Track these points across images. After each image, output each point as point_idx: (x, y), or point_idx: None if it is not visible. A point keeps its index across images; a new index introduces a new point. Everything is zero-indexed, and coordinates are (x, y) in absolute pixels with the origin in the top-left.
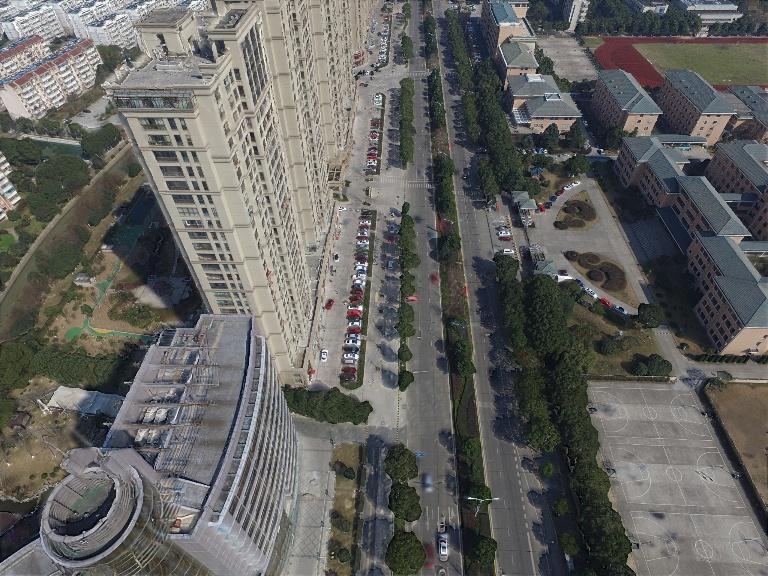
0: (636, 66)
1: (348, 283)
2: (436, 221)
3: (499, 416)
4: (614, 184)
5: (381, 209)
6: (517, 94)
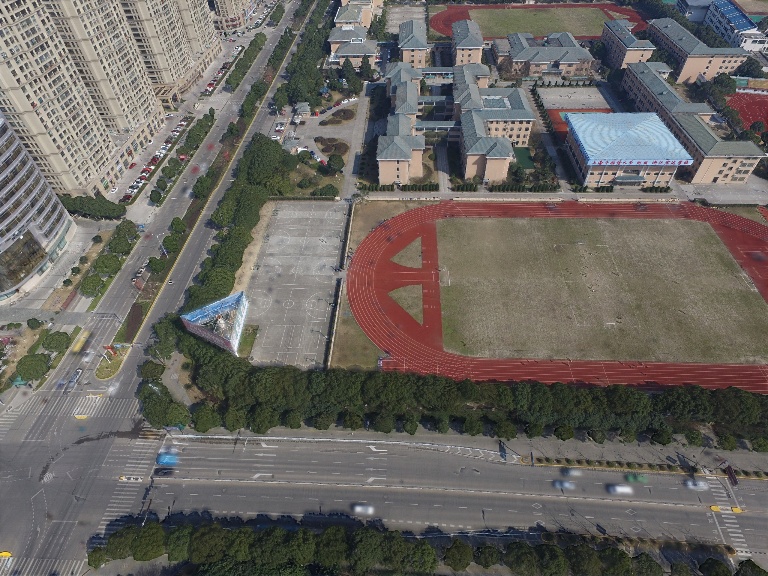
0: None
1: (152, 155)
2: (236, 122)
3: None
4: (380, 99)
5: (200, 116)
6: (331, 39)
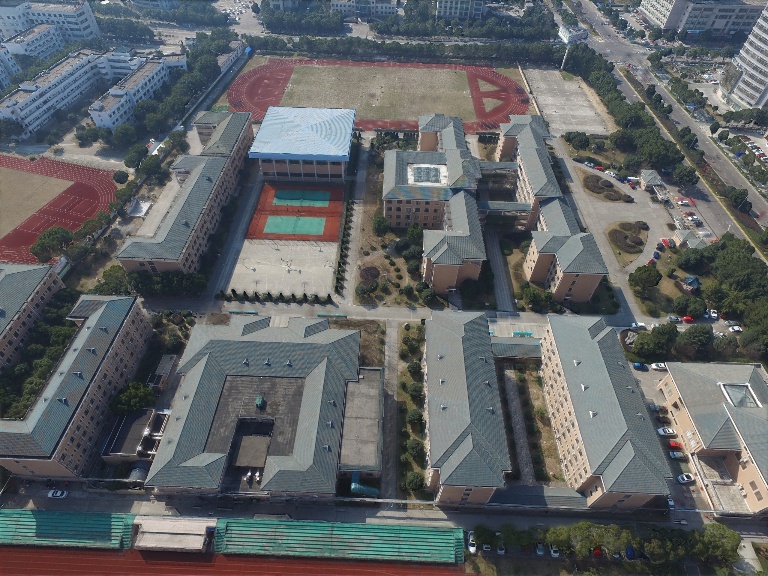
0: None
1: None
2: None
3: None
4: None
5: None
6: None
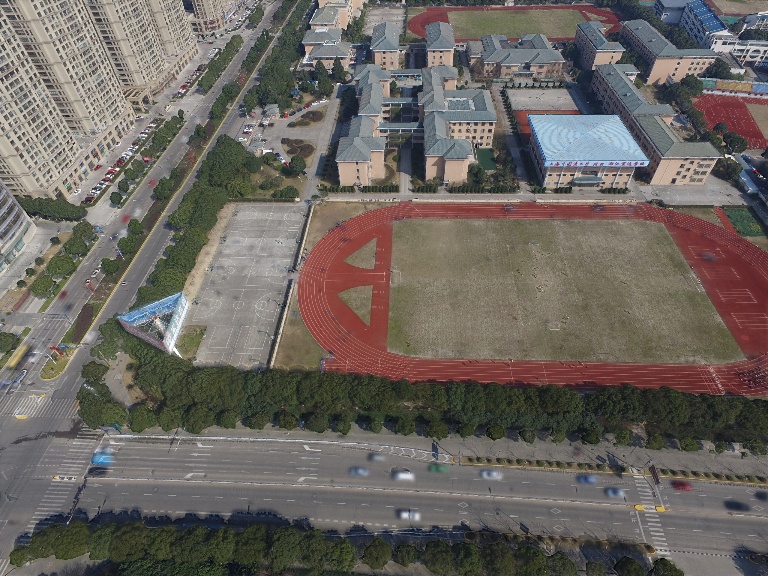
0: None
1: (118, 157)
2: (205, 124)
3: None
4: (351, 101)
5: (170, 118)
6: (304, 42)
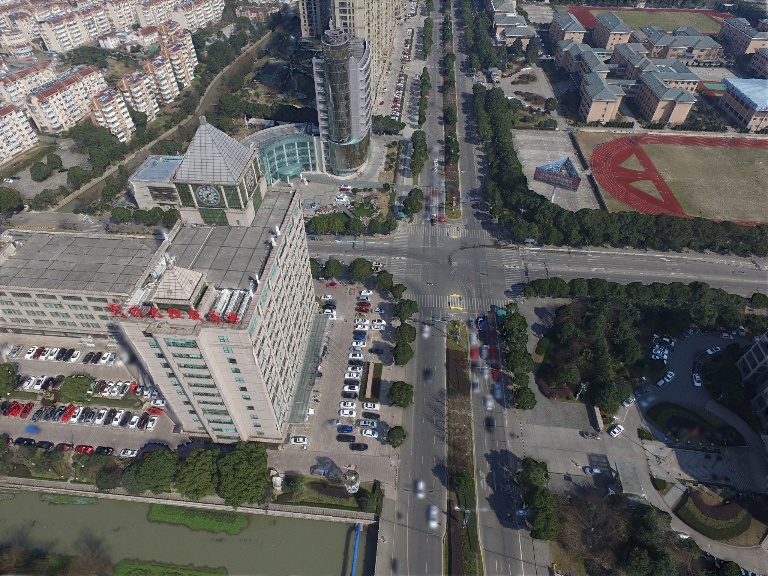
0: (587, 21)
1: (392, 98)
2: (442, 80)
3: (467, 137)
4: (552, 69)
5: (410, 74)
6: (499, 23)
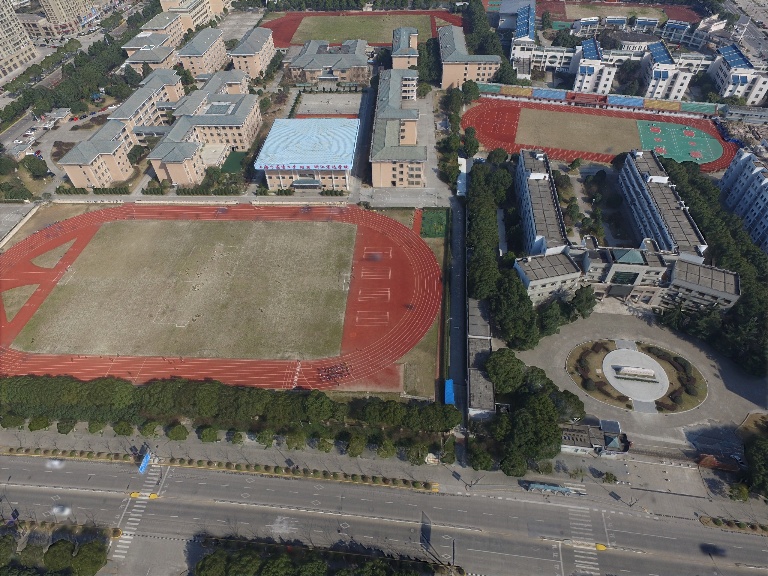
0: (283, 32)
1: None
2: None
3: None
4: None
5: None
6: (124, 46)
